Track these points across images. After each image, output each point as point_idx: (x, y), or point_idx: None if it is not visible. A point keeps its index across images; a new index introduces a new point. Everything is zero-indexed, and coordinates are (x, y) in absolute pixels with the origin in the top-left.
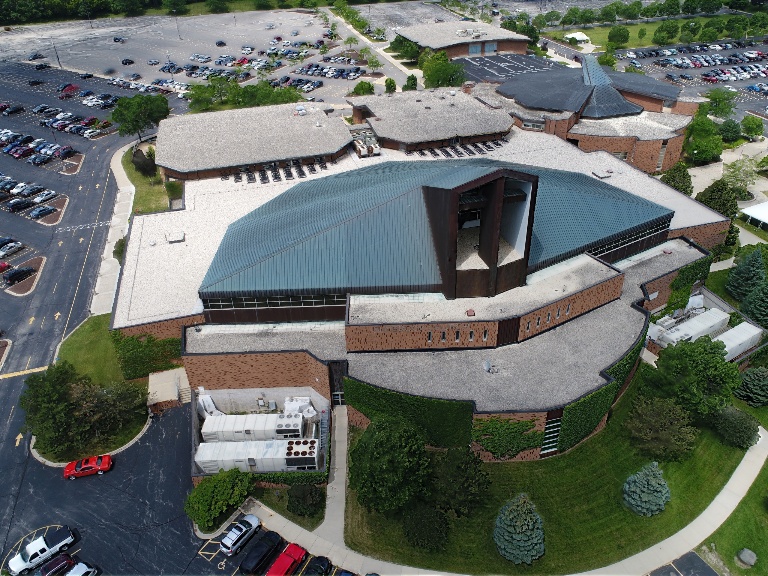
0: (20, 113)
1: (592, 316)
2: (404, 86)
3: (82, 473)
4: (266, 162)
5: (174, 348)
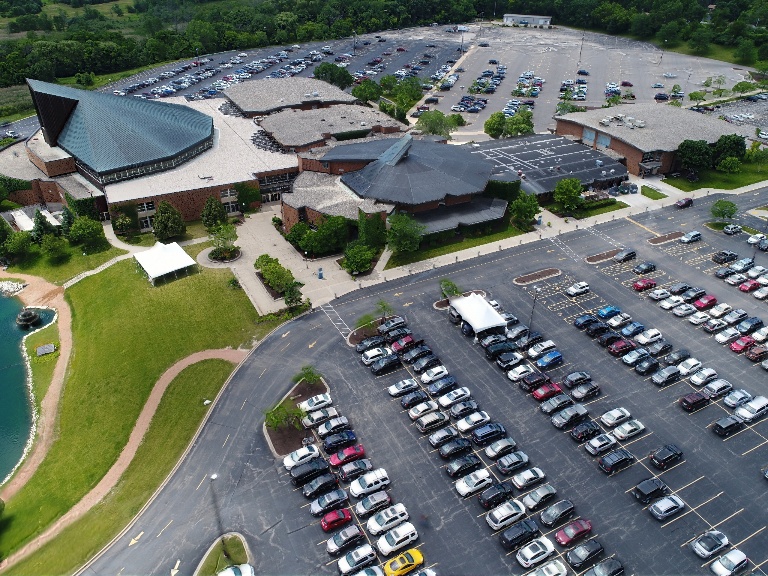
0: (373, 65)
1: None
2: None
3: None
4: None
5: None
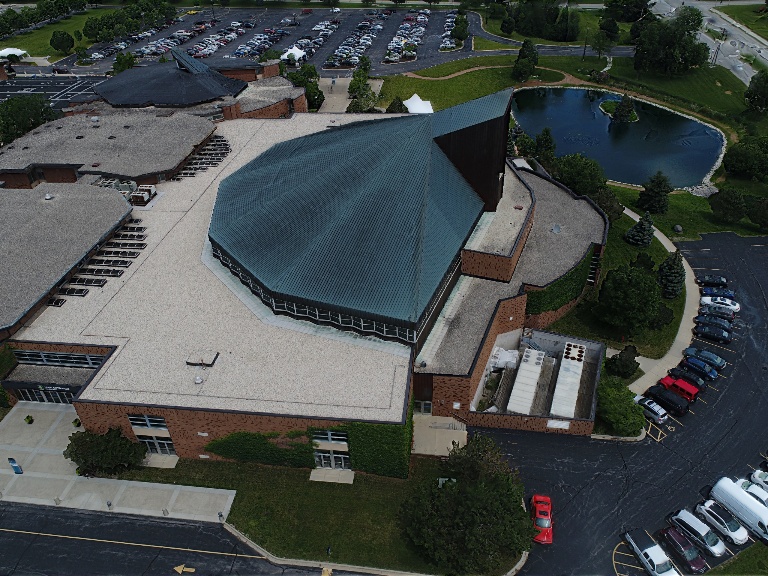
0: None
1: None
2: (4, 136)
3: None
4: None
5: None
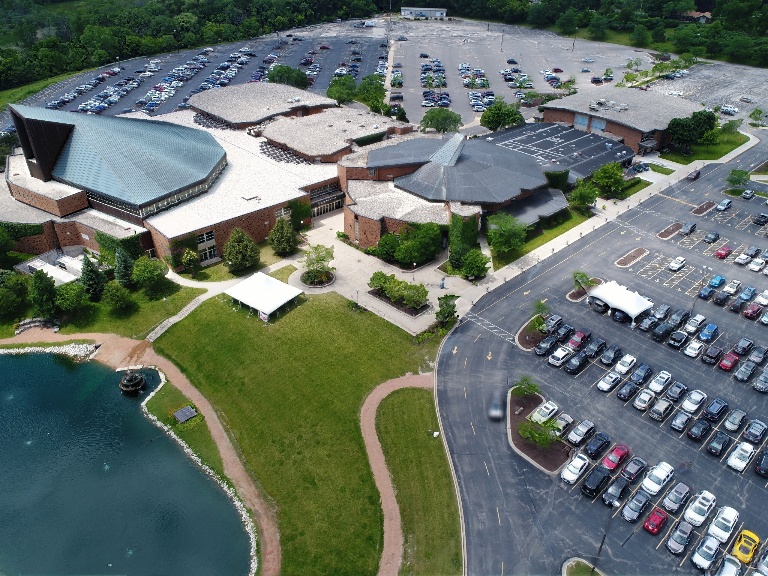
0: (306, 65)
1: (42, 213)
2: None
3: None
4: (210, 113)
5: None
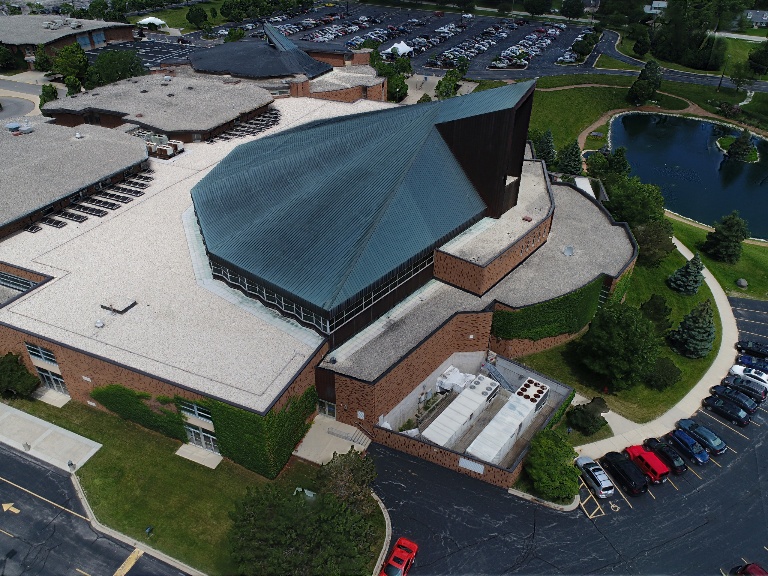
0: None
1: None
2: (86, 83)
3: (405, 575)
4: (78, 191)
5: (309, 402)
